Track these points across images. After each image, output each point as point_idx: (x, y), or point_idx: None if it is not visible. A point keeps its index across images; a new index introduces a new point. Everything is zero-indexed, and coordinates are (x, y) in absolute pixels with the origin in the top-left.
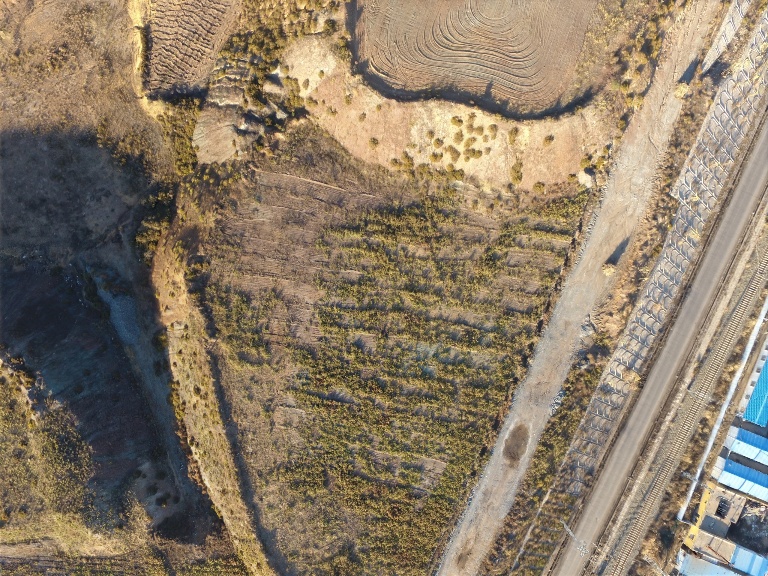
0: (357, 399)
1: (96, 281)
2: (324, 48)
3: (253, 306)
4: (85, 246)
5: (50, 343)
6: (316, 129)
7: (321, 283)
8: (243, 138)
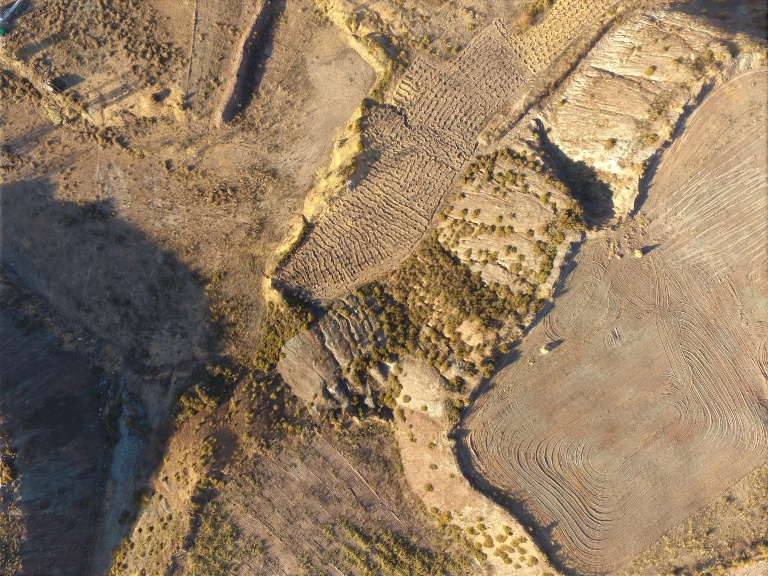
0: None
1: (124, 410)
2: (441, 395)
3: (237, 543)
4: (136, 368)
5: (49, 446)
6: (390, 434)
7: (306, 563)
8: (325, 400)
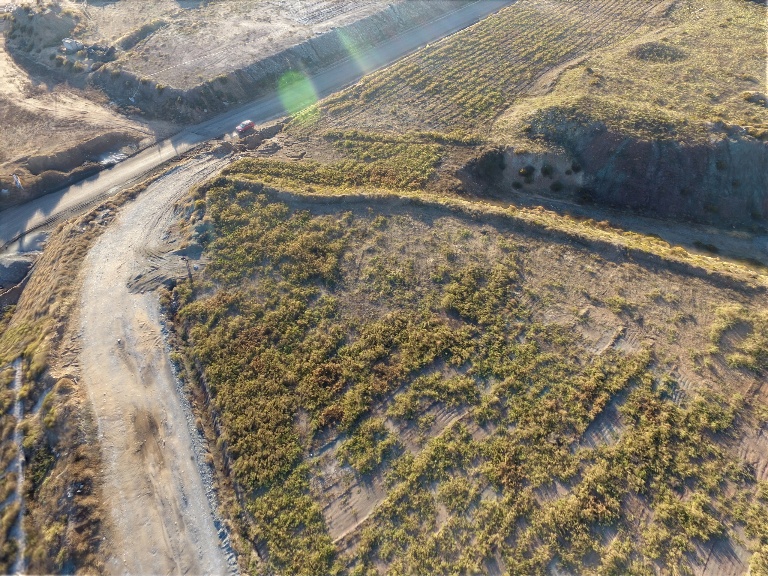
0: (585, 454)
1: None
2: None
3: None
4: None
5: None
6: None
7: None
8: None
